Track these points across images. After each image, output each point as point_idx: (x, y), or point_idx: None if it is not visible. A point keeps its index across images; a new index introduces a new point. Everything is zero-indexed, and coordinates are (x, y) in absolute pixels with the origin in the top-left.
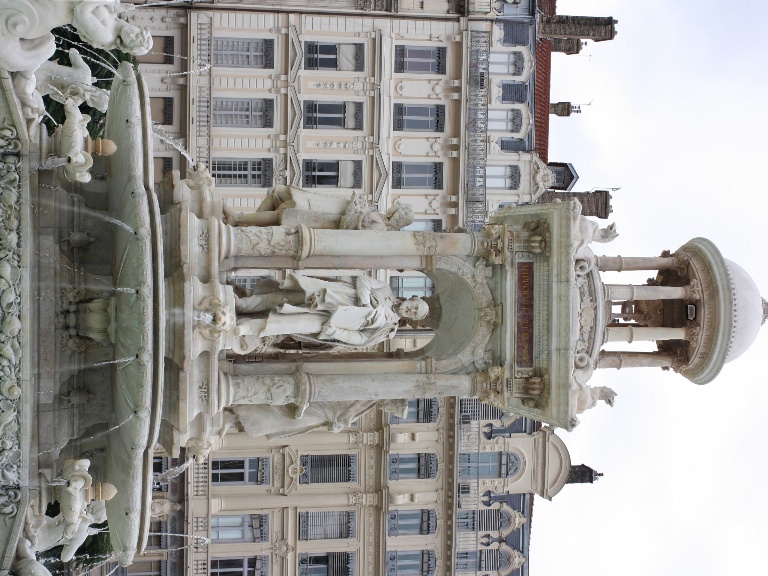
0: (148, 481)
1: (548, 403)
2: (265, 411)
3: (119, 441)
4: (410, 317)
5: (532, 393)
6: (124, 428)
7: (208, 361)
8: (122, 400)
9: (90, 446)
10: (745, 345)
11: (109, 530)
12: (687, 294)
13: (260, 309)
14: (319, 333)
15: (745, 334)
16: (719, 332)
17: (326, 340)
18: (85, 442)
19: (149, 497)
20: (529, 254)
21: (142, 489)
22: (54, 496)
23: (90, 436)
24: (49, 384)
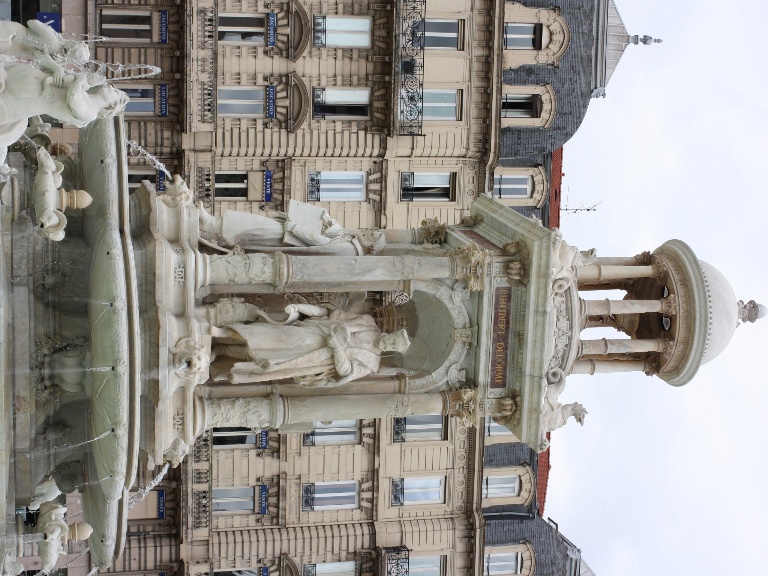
0: (128, 243)
1: (528, 248)
2: (254, 325)
3: (95, 244)
4: (370, 244)
5: (509, 249)
6: (93, 171)
7: (178, 243)
8: (88, 151)
9: (71, 330)
10: (721, 283)
11: (100, 385)
12: (636, 257)
13: (224, 245)
14: (283, 237)
15: (712, 270)
16: (679, 254)
17: (292, 246)
18: (65, 321)
19: (131, 255)
20: (466, 228)
21: (123, 250)
22: (27, 192)
23: (69, 317)
24: (19, 174)
